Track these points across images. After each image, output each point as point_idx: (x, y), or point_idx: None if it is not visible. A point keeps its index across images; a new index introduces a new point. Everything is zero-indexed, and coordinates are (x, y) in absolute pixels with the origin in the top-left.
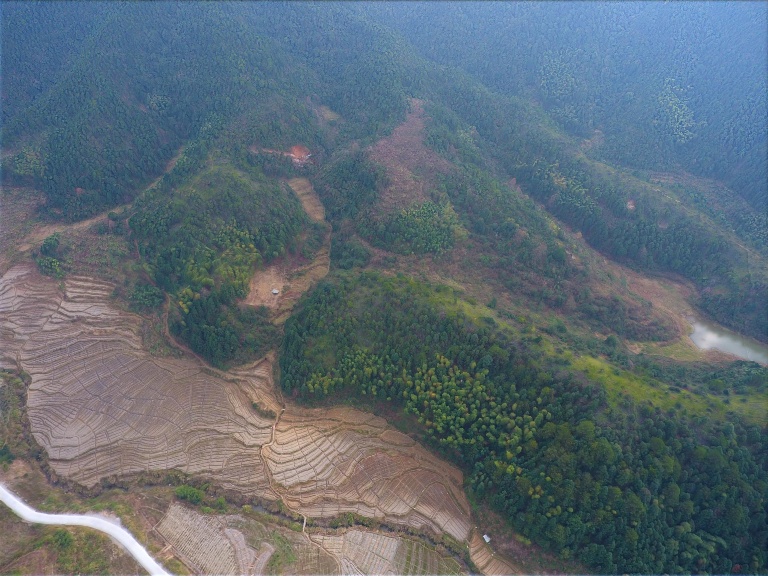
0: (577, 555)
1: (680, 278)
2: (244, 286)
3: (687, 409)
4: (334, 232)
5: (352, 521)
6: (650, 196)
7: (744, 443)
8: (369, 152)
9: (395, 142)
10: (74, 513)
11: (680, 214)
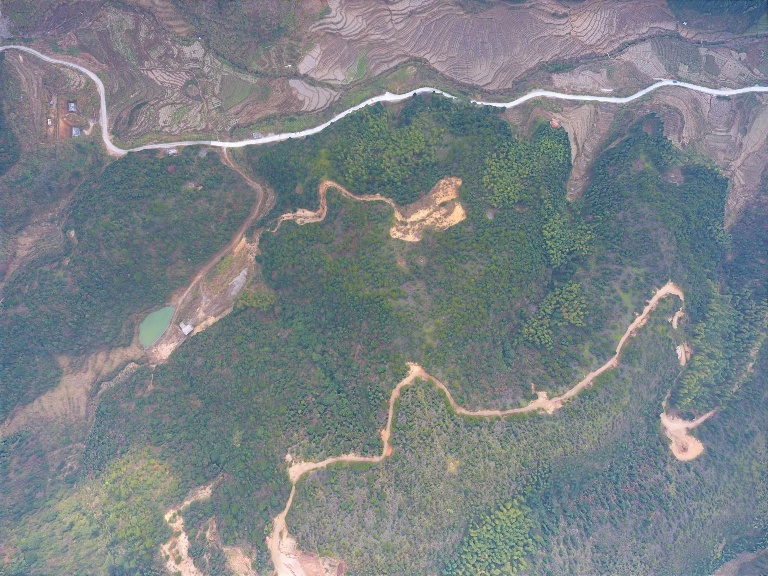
0: (730, 10)
1: None
2: None
3: None
4: None
5: (627, 45)
6: None
7: None
8: None
9: None
10: (523, 96)
11: None
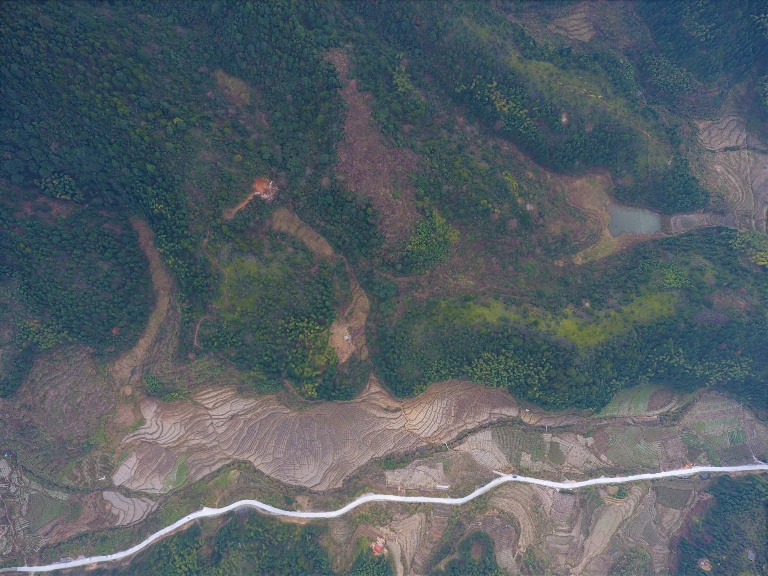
0: None
1: (601, 170)
2: (335, 358)
3: (615, 332)
4: (350, 264)
5: (467, 433)
6: (579, 104)
7: None
8: (342, 183)
9: (356, 155)
10: (351, 502)
11: (602, 112)
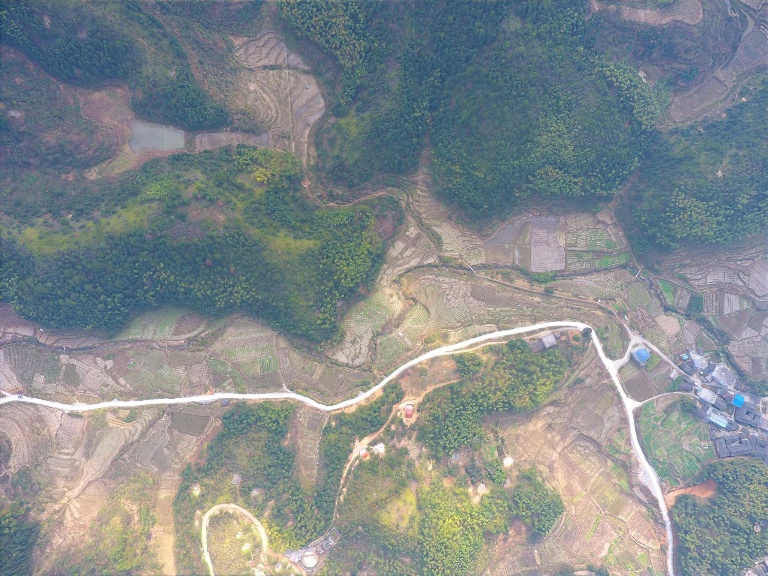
0: (71, 325)
1: (118, 83)
2: None
3: (83, 242)
4: None
5: None
6: (56, 5)
7: (116, 247)
8: None
9: None
10: None
11: (89, 17)
